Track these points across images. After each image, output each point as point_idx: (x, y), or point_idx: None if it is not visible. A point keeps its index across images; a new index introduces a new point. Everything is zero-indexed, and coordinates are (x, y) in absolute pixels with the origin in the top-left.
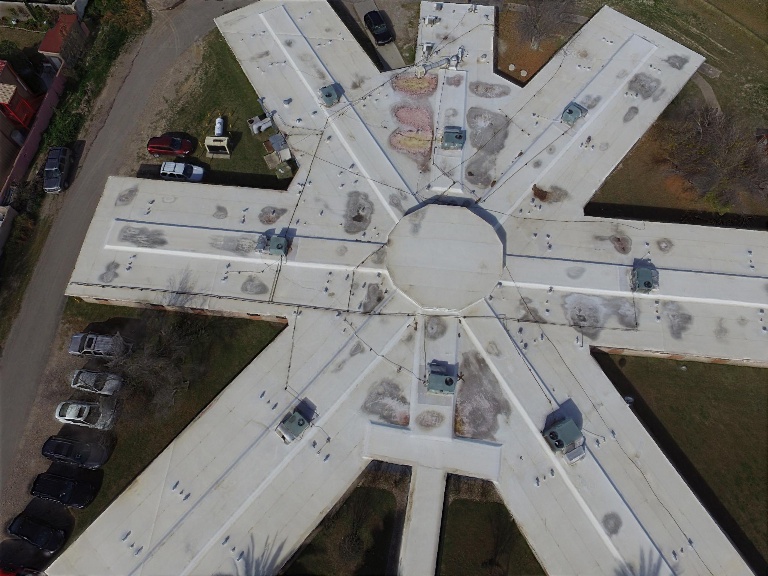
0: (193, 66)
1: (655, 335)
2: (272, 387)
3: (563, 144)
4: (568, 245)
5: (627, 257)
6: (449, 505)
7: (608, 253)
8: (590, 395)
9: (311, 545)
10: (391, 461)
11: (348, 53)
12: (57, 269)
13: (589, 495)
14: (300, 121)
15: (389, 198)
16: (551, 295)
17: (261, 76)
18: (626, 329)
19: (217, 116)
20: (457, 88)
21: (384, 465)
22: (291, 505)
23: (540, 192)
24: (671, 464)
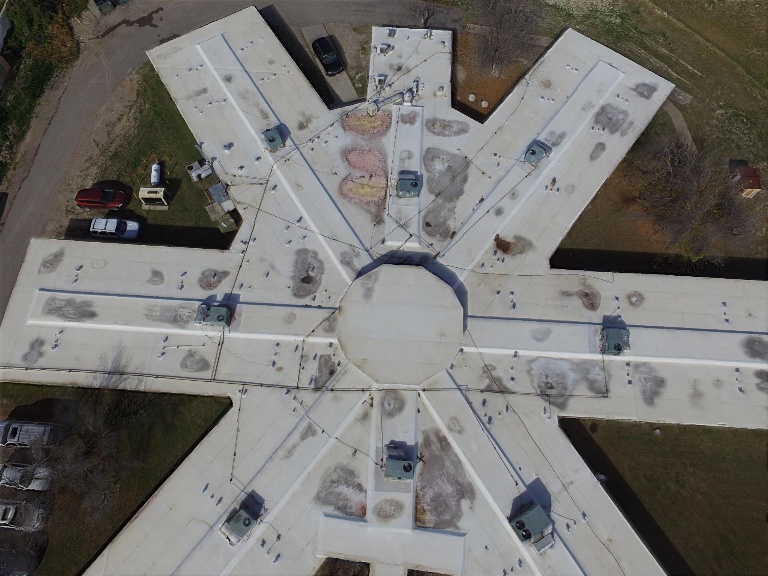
0: (126, 104)
1: (626, 401)
2: (216, 479)
3: (527, 188)
4: (533, 303)
5: (596, 314)
6: None
7: (576, 310)
8: (559, 473)
9: None
10: (347, 558)
11: (294, 88)
12: None
13: None
14: (242, 169)
15: (341, 256)
16: (516, 360)
17: (199, 117)
18: (596, 396)
19: (154, 161)
20: (412, 126)
21: None
22: None
23: (503, 243)
24: (645, 546)
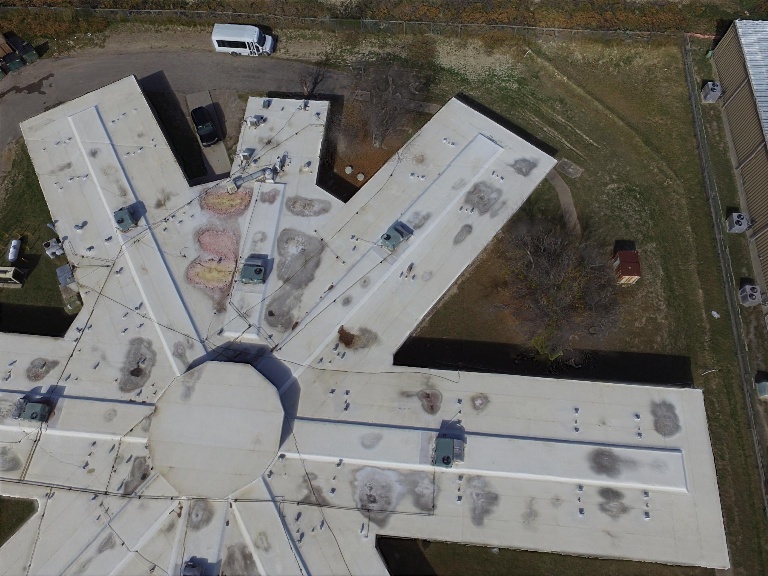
0: (0, 174)
1: (453, 521)
2: None
3: (380, 274)
4: (368, 404)
5: (434, 418)
6: None
7: (413, 413)
8: None
9: None
10: None
11: (158, 163)
12: None
13: None
14: (91, 250)
15: (173, 347)
16: (340, 469)
17: (58, 194)
18: (420, 513)
19: (17, 235)
20: (271, 206)
21: None
22: None
23: (346, 335)
24: None
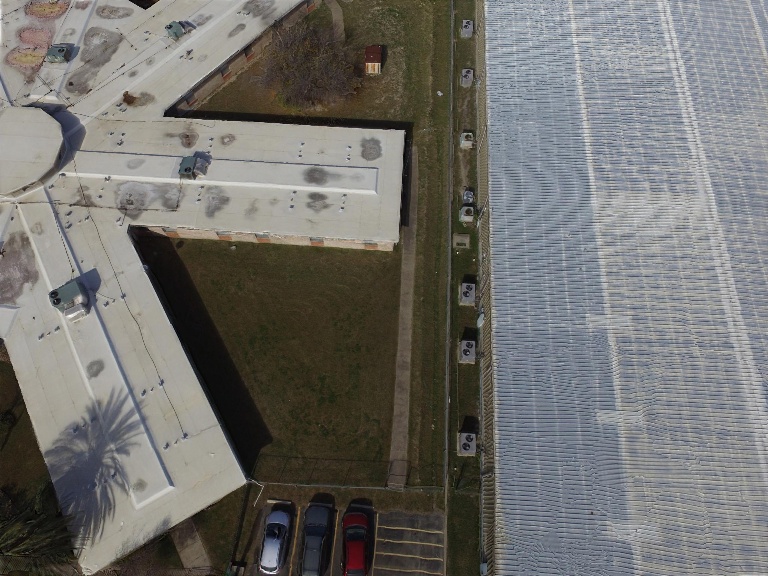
0: None
1: (190, 214)
2: None
3: (163, 56)
4: (138, 141)
5: (190, 150)
6: None
7: (173, 147)
8: (114, 265)
9: None
10: None
11: None
12: None
13: (82, 346)
14: None
15: None
16: (108, 183)
17: None
18: (166, 210)
19: None
20: (83, 11)
21: None
22: None
23: (130, 98)
24: (168, 320)
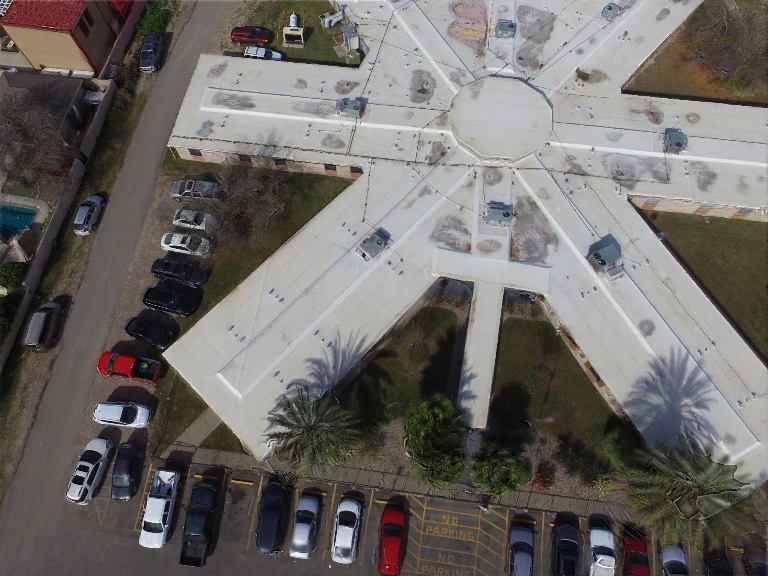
0: None
1: (684, 187)
2: (351, 219)
3: (603, 36)
4: (608, 116)
5: (659, 127)
6: (503, 322)
7: (643, 123)
8: (627, 231)
9: (384, 350)
10: (456, 277)
11: None
12: (154, 133)
13: (627, 306)
14: (369, 13)
15: (450, 75)
16: (593, 154)
17: None
18: (659, 182)
19: (291, 14)
20: None
21: (446, 290)
22: (371, 308)
23: (583, 74)
24: (697, 286)
